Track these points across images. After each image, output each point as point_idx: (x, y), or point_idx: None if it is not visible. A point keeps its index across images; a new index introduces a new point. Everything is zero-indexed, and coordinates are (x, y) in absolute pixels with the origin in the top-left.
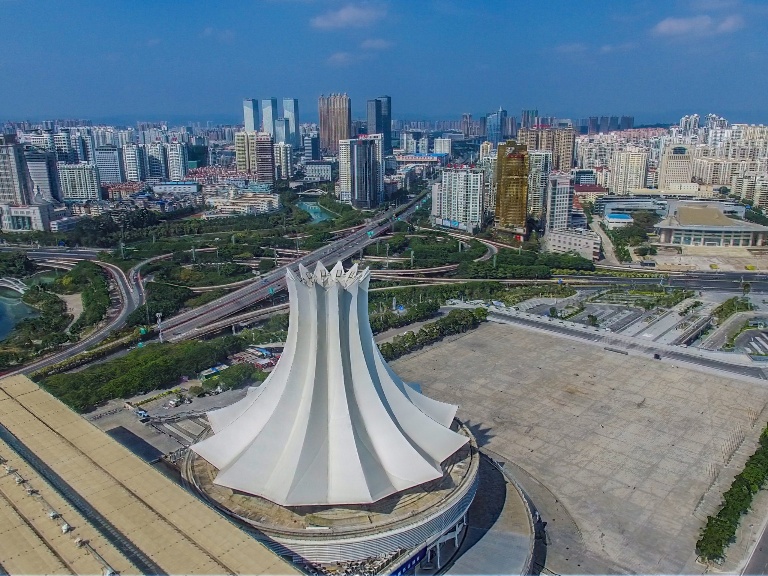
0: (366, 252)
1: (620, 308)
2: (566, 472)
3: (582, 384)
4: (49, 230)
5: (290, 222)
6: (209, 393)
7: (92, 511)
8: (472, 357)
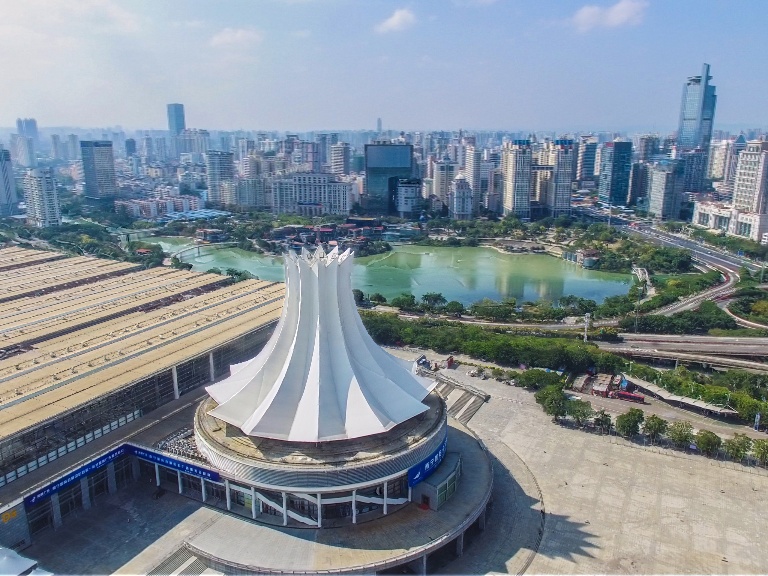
0: None
1: None
2: None
3: None
4: (760, 240)
5: None
6: None
7: None
8: None
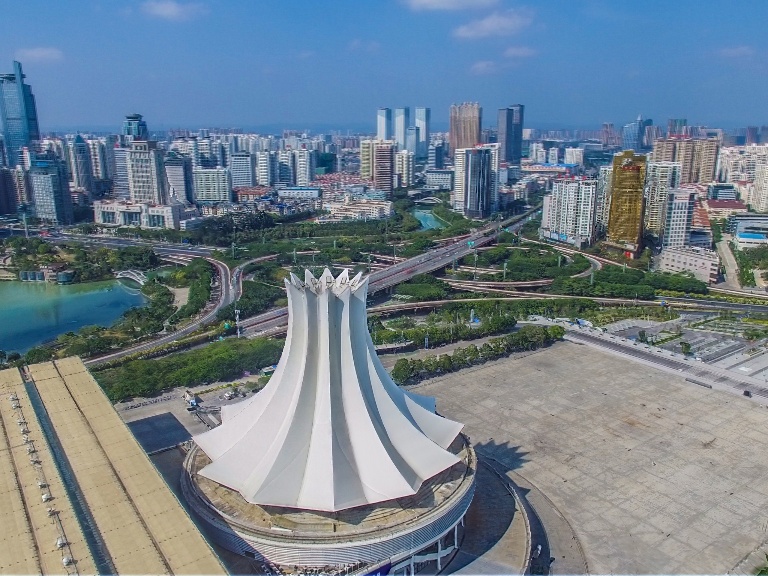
0: (463, 262)
1: (725, 337)
2: (595, 508)
3: (646, 416)
4: (178, 228)
5: (399, 229)
6: None
7: (75, 485)
8: (534, 376)
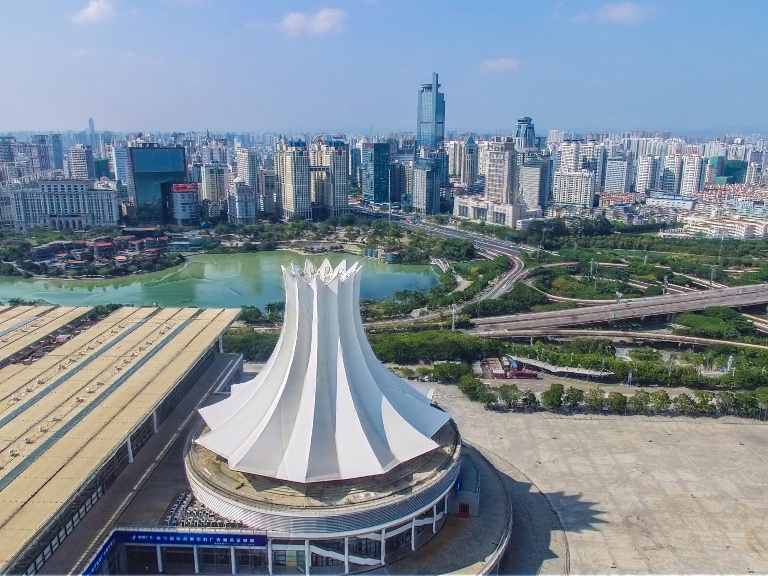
0: None
1: None
2: None
3: None
4: (515, 227)
5: (767, 254)
6: (418, 378)
7: None
8: (724, 448)
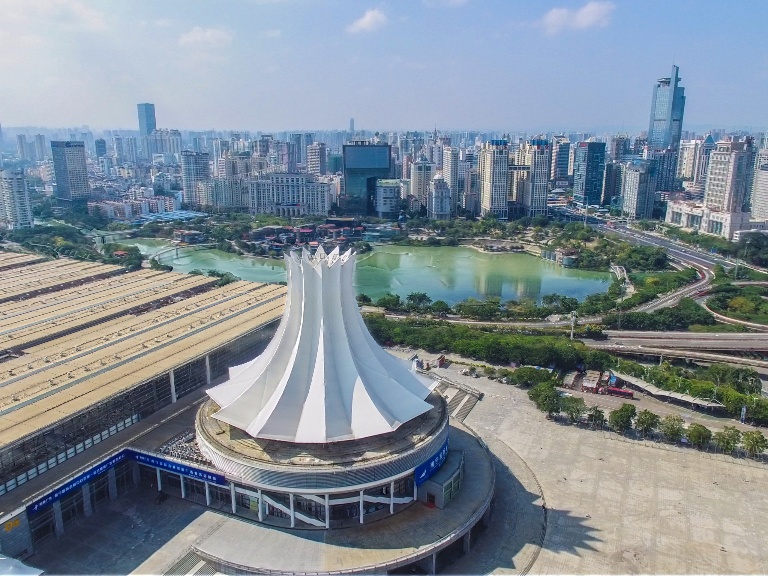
0: None
1: None
2: None
3: None
4: (731, 238)
5: None
6: None
7: None
8: None
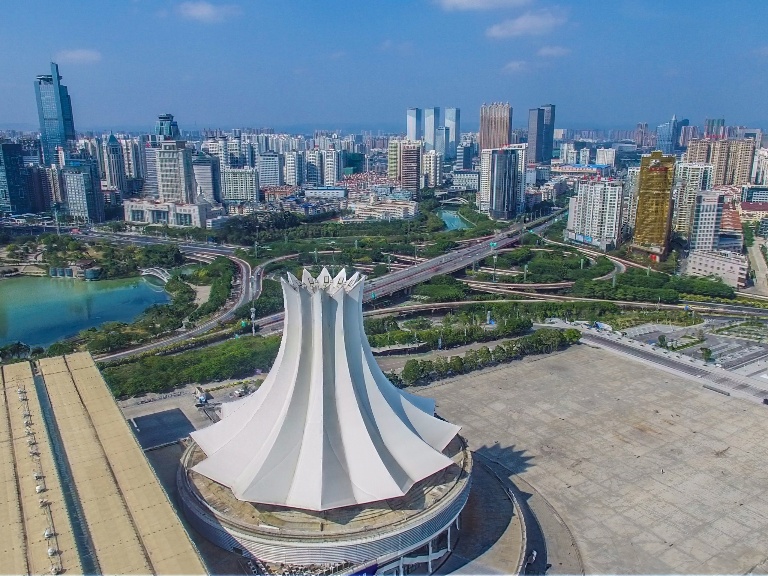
0: (484, 263)
1: (749, 343)
2: (598, 515)
3: (659, 422)
4: (205, 227)
5: (423, 230)
6: None
7: (70, 477)
8: (546, 380)
